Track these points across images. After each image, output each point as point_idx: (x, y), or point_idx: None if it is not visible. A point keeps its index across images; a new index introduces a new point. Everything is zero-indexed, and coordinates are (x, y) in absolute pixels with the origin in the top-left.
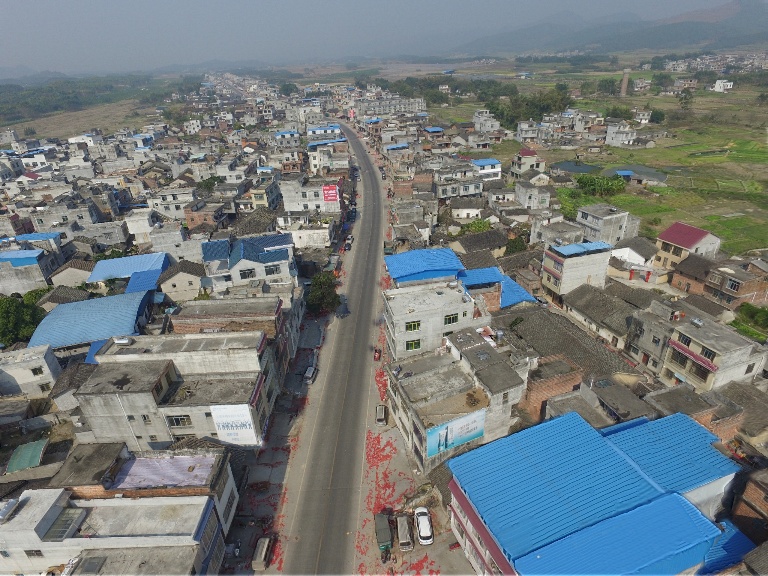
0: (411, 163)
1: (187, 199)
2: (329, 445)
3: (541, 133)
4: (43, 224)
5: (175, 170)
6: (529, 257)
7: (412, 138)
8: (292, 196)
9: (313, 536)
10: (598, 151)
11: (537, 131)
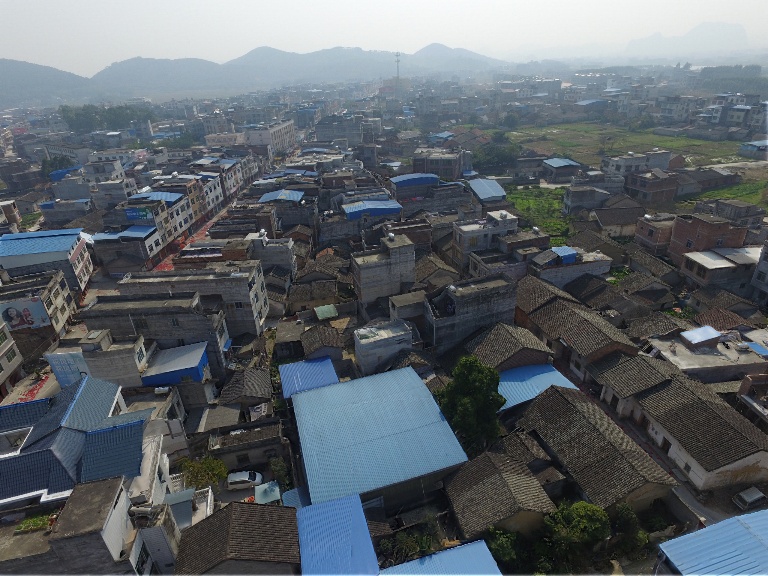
0: None
1: None
2: None
3: None
4: None
5: None
6: None
7: None
8: None
9: None
10: None
11: None
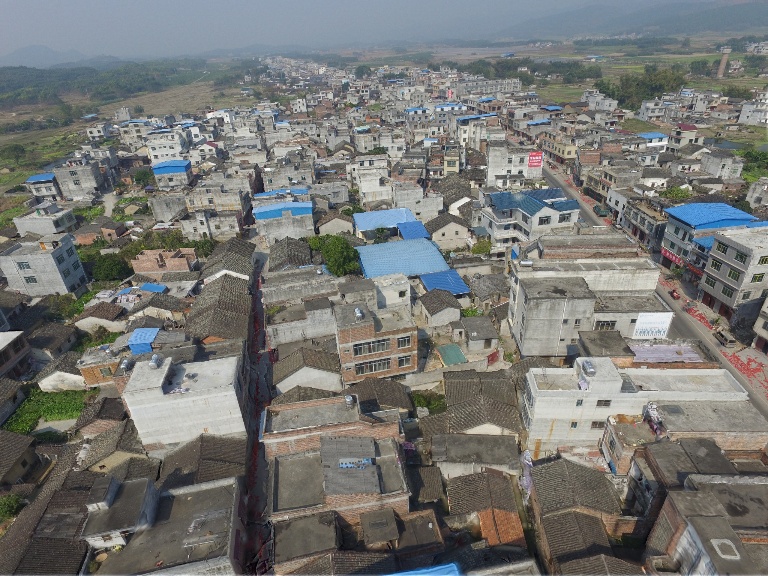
0: (575, 136)
1: (382, 165)
2: None
3: (670, 111)
4: (272, 183)
5: (331, 142)
6: (766, 218)
7: (548, 114)
8: (498, 162)
9: None
10: (736, 129)
11: (664, 110)
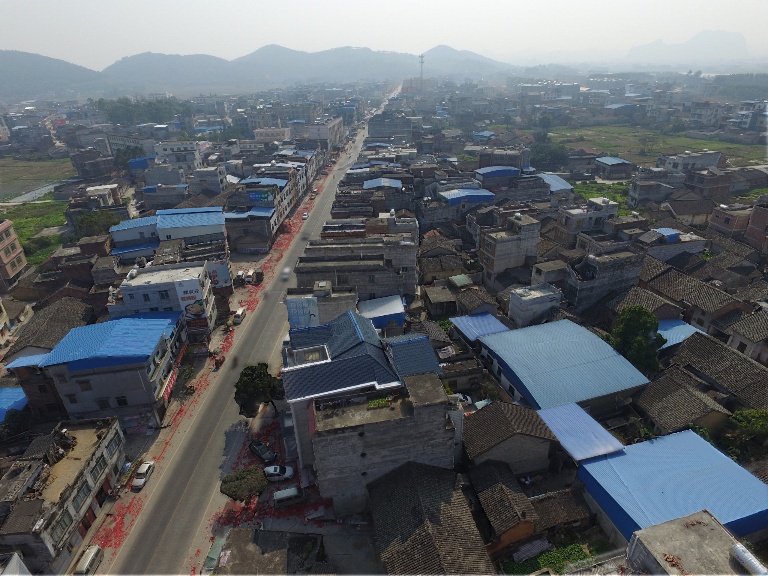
0: None
1: None
2: (280, 306)
3: None
4: None
5: None
6: None
7: None
8: None
9: (293, 279)
10: None
11: None
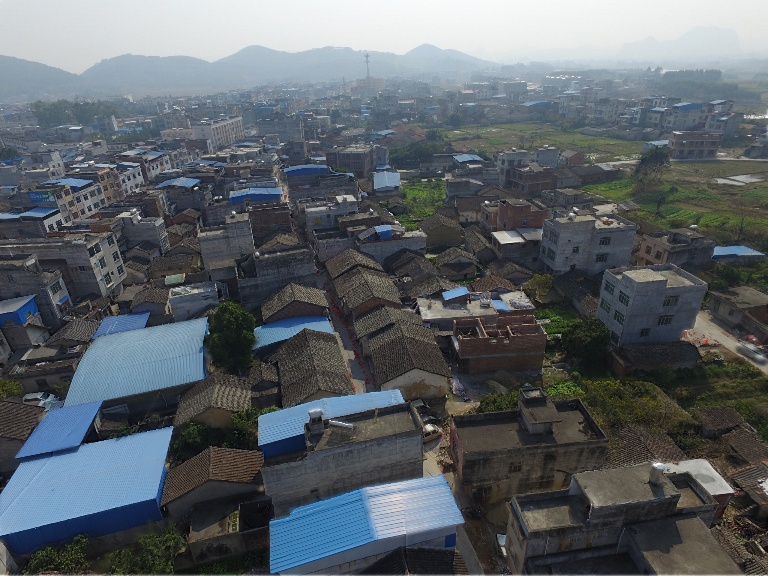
0: None
1: None
2: None
3: None
4: None
5: None
6: None
7: None
8: None
9: None
10: None
11: None
